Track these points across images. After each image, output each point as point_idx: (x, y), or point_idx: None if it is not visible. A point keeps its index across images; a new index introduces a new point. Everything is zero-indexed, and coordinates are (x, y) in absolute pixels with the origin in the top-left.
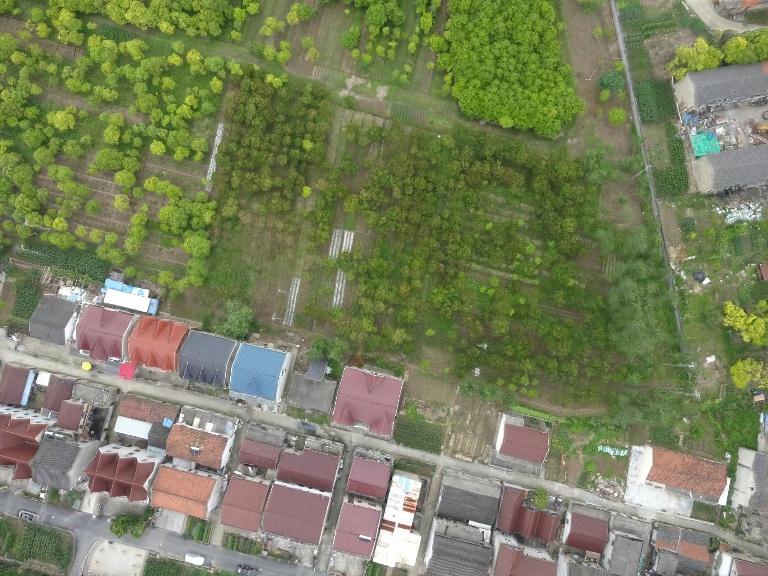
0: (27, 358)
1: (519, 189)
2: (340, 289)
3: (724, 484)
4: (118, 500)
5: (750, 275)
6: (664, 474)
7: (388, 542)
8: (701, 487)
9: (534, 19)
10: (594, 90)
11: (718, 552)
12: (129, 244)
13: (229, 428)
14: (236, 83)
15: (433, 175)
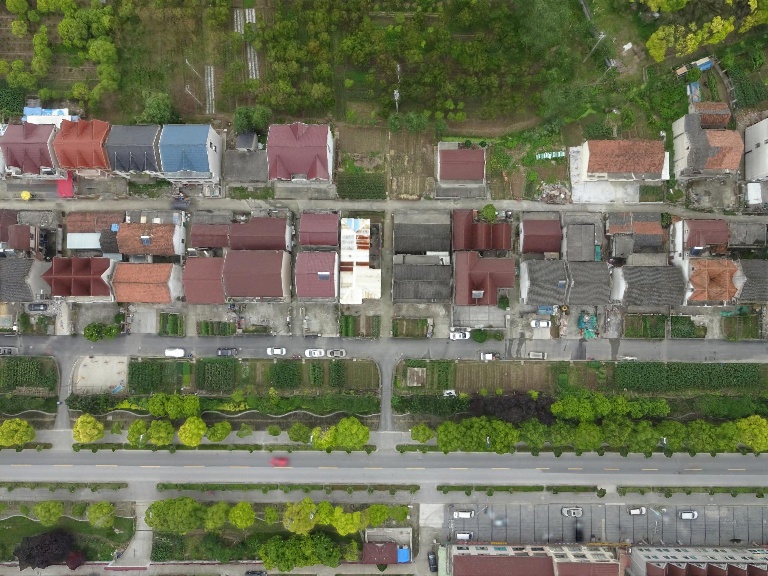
0: None
1: None
2: (254, 66)
3: (662, 156)
4: (89, 316)
5: None
6: (603, 161)
7: (350, 281)
8: (641, 166)
9: None
10: None
11: (672, 226)
12: (35, 63)
13: (176, 219)
14: None
15: None
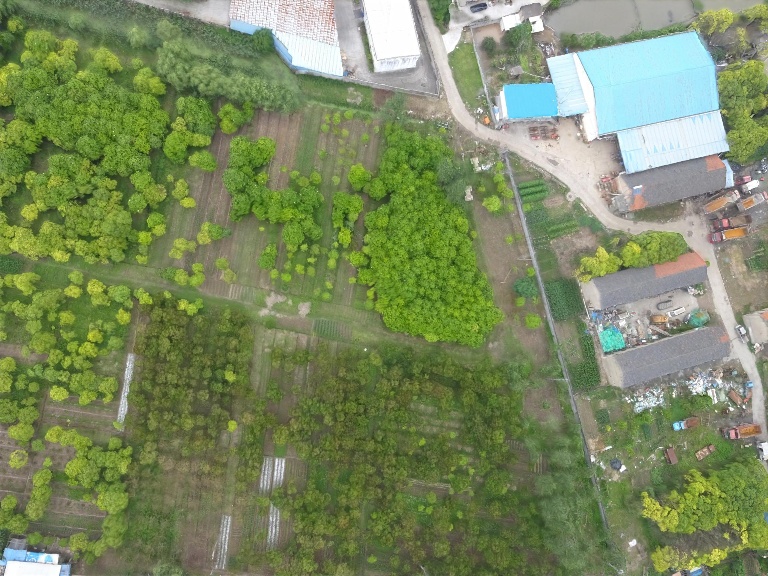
0: None
1: (448, 403)
2: (275, 522)
3: None
4: None
5: (659, 458)
6: None
7: None
8: None
9: (451, 236)
10: (509, 292)
11: None
12: (32, 511)
13: None
14: (146, 314)
15: (363, 397)
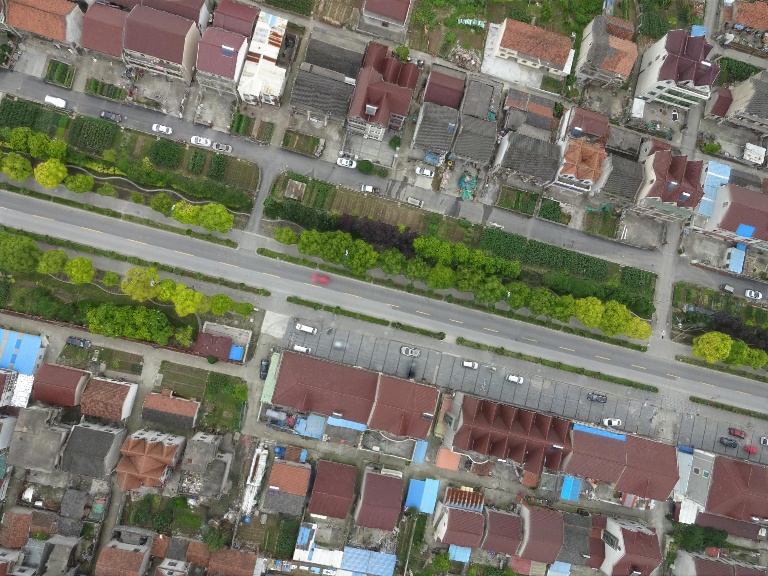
0: None
1: None
2: None
3: (568, 50)
4: None
5: None
6: (516, 39)
7: (253, 72)
8: (548, 54)
9: None
10: None
11: (562, 117)
12: None
13: None
14: None
15: None
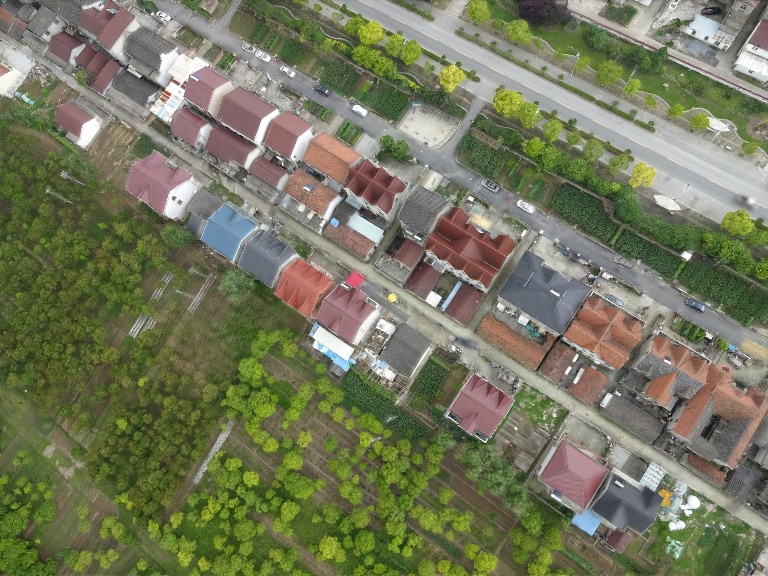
0: (450, 326)
1: None
2: (160, 290)
3: None
4: (408, 176)
5: None
6: None
7: None
8: None
9: None
10: None
11: None
12: (305, 391)
13: (287, 202)
14: (158, 513)
15: (37, 354)
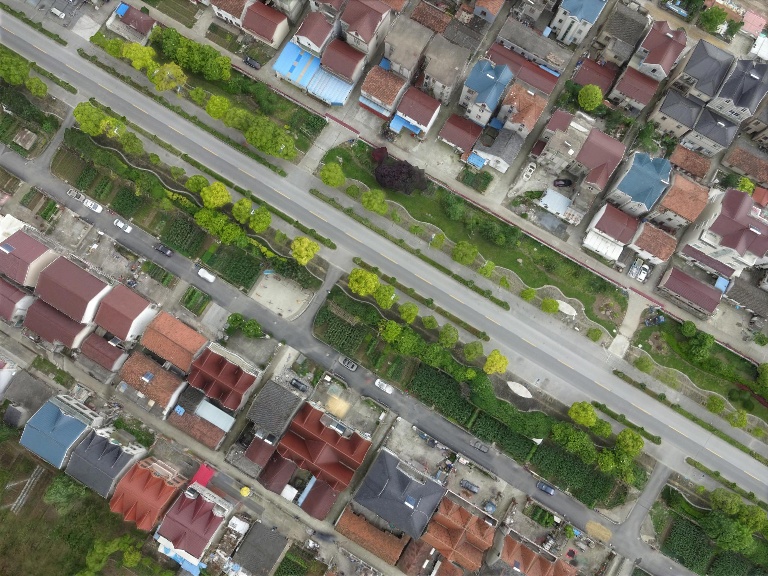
0: (307, 518)
1: None
2: None
3: None
4: (261, 351)
5: None
6: None
7: (3, 237)
8: None
9: None
10: None
11: None
12: None
13: (124, 386)
14: None
15: None
